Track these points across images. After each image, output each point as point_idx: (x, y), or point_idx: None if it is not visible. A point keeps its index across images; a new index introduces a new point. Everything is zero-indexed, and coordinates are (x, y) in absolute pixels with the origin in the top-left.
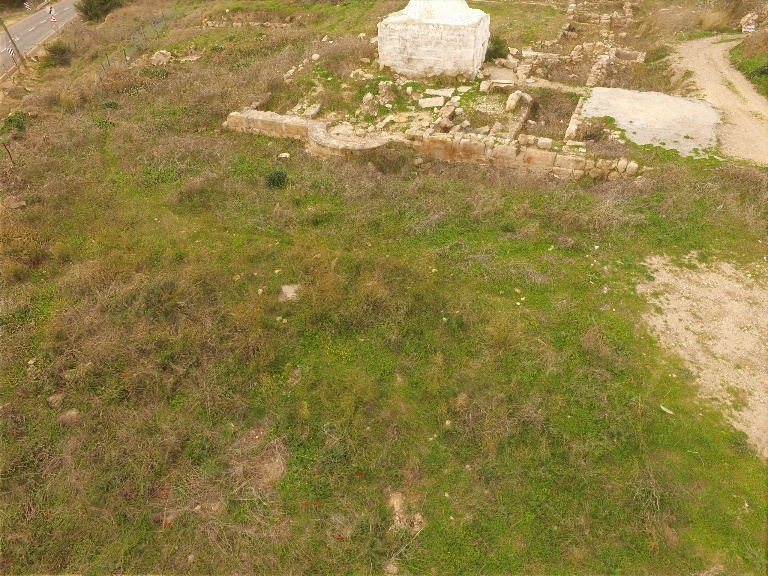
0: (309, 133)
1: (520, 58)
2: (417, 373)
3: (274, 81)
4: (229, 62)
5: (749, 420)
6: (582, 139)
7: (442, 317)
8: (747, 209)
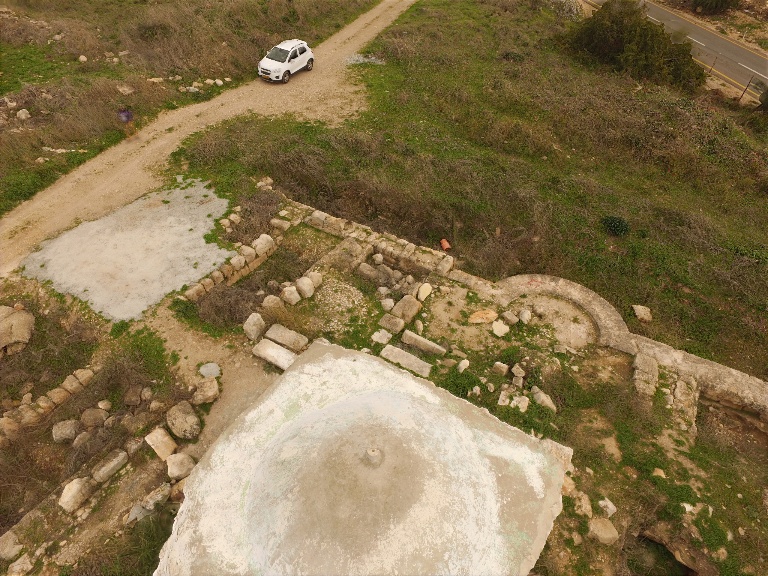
0: None
1: None
2: None
3: None
4: None
5: None
6: None
7: None
8: None
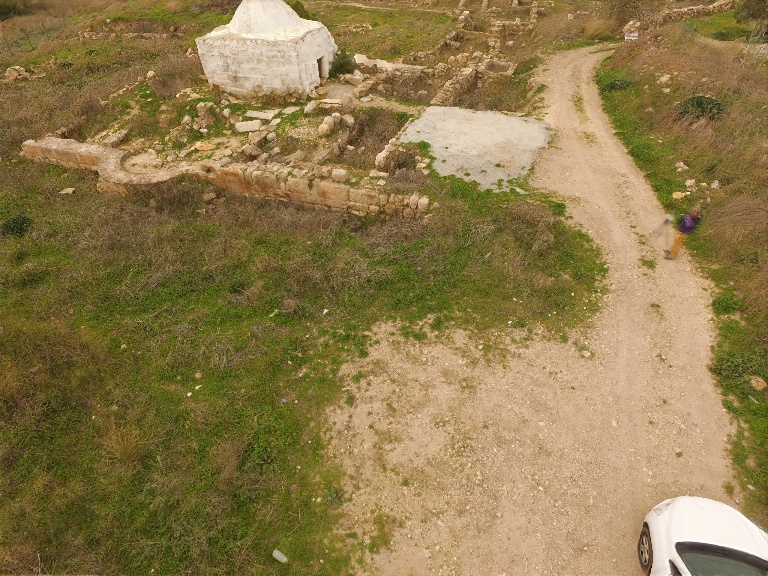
0: (98, 165)
1: (374, 73)
2: (7, 503)
3: (88, 103)
4: (71, 79)
5: (379, 567)
6: (395, 167)
7: (91, 415)
8: None
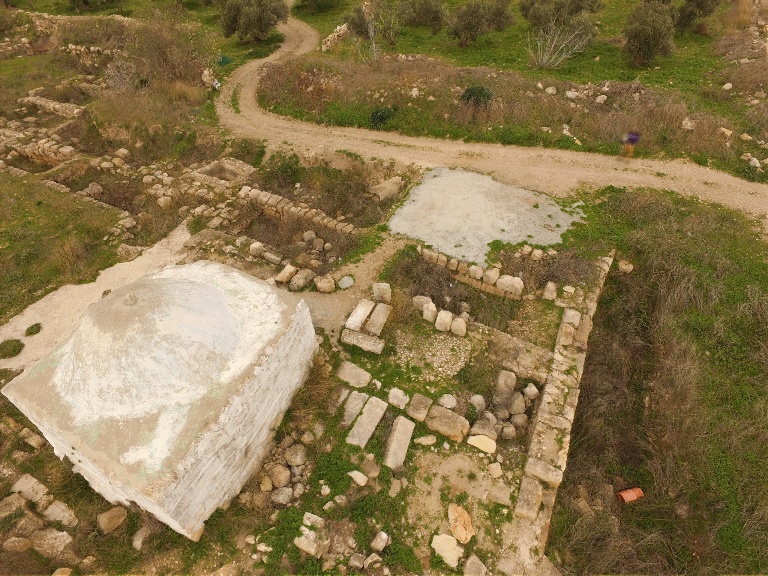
0: None
1: None
2: None
3: None
4: None
5: None
6: None
7: None
8: (681, 221)
